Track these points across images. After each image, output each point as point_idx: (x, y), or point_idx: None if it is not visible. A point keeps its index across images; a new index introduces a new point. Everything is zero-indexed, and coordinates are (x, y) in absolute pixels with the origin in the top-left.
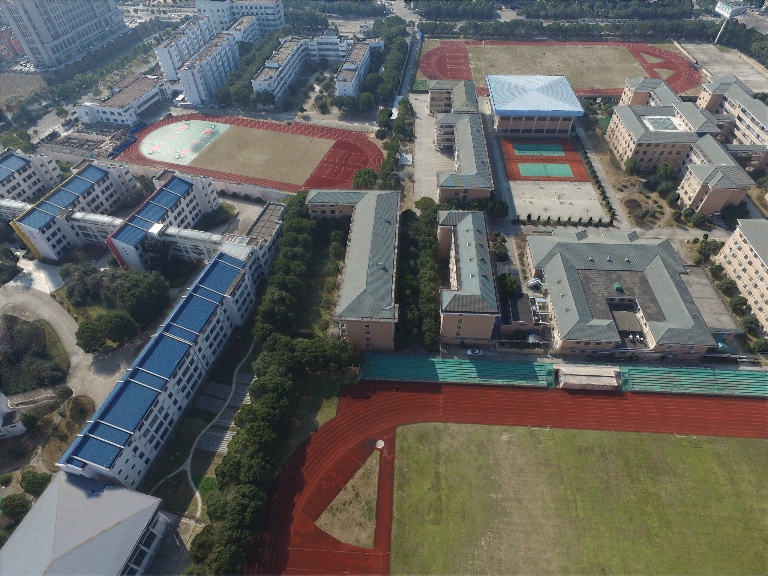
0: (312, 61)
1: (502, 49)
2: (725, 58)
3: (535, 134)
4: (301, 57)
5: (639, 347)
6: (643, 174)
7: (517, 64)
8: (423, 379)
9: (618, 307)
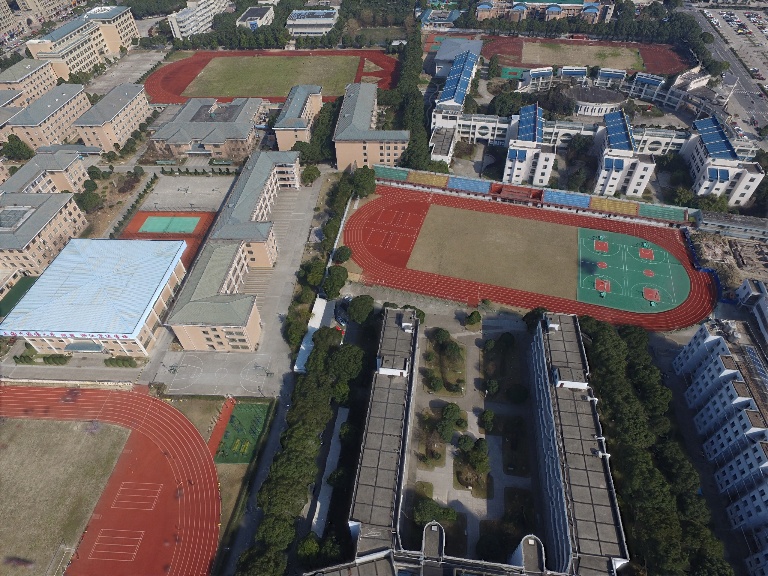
0: None
1: None
2: None
3: None
4: None
5: None
6: None
7: None
8: None
9: None
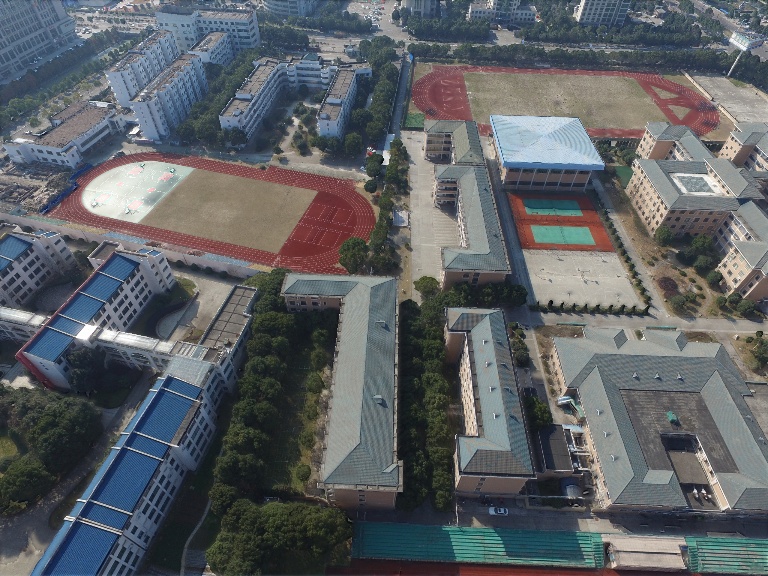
0: (290, 88)
1: (502, 77)
2: (741, 94)
3: (547, 187)
4: (278, 83)
5: (706, 507)
6: (674, 242)
7: (519, 96)
8: (435, 559)
9: (673, 443)
